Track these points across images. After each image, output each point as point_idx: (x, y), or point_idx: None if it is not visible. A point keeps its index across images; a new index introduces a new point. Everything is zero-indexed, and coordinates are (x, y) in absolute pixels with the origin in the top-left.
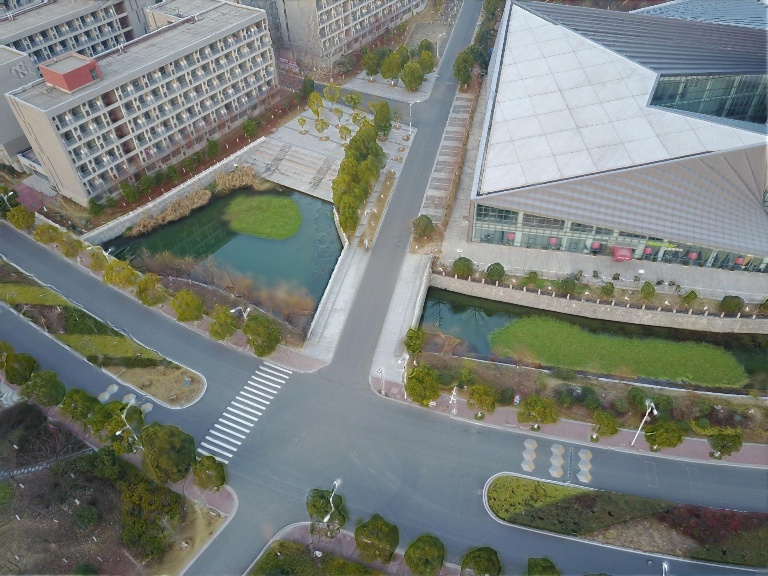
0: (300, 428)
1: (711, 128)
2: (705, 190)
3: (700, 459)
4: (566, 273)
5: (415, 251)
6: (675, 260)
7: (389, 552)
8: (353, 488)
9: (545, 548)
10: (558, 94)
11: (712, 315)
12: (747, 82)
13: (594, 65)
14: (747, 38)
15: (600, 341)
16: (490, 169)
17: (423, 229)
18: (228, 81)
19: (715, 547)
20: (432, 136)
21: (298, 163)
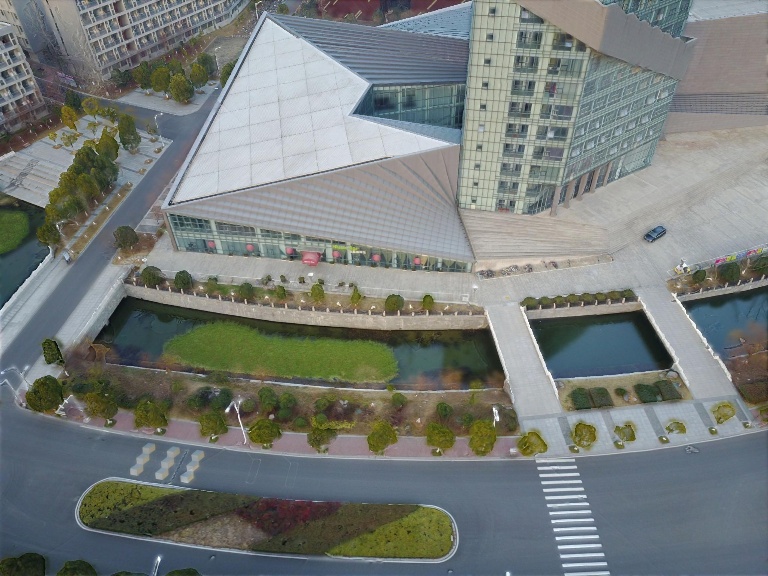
0: None
1: (397, 135)
2: (390, 194)
3: (306, 454)
4: (256, 278)
5: (117, 262)
6: (363, 262)
7: None
8: None
9: (118, 550)
10: (276, 105)
11: (376, 314)
12: None
13: (317, 76)
14: (462, 49)
15: (271, 344)
16: (189, 179)
17: (122, 240)
18: None
19: (277, 538)
20: (184, 148)
21: (42, 177)
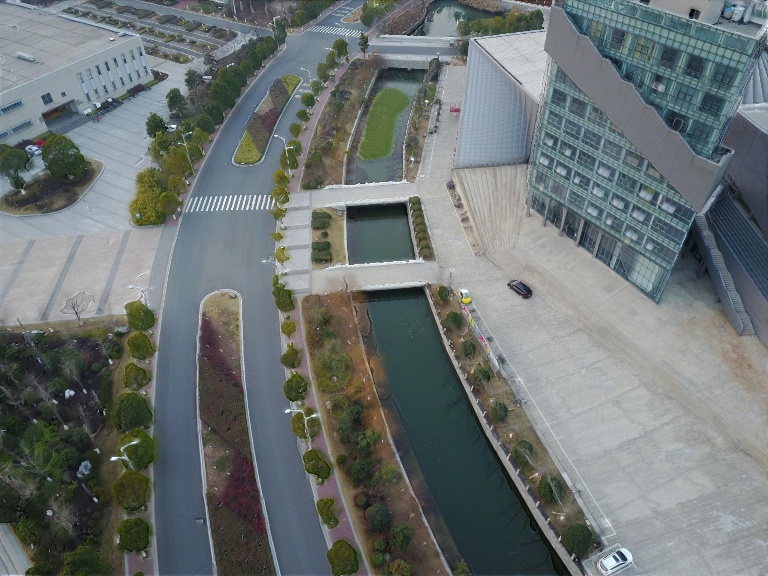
0: None
1: None
2: None
3: None
4: None
5: None
6: None
7: None
8: None
9: None
10: None
11: None
12: None
13: None
14: None
15: (392, 117)
16: None
17: None
18: None
19: None
20: None
21: None
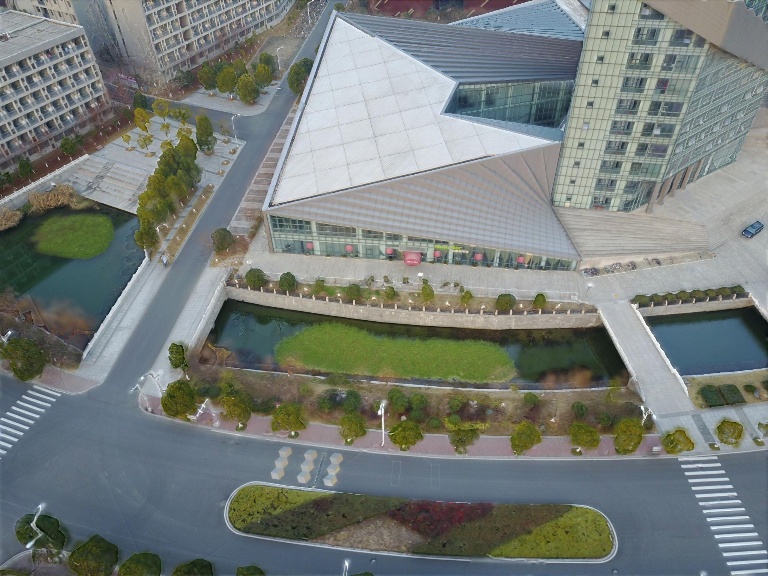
0: (54, 452)
1: (494, 133)
2: (490, 193)
3: (445, 455)
4: (359, 279)
5: (215, 264)
6: (464, 262)
7: (104, 573)
8: (96, 510)
9: (275, 555)
10: (362, 104)
11: (487, 313)
12: (547, 88)
13: (400, 75)
14: (544, 47)
15: (383, 345)
16: (286, 180)
17: (220, 242)
18: (46, 99)
19: (436, 540)
20: (259, 148)
21: (119, 180)
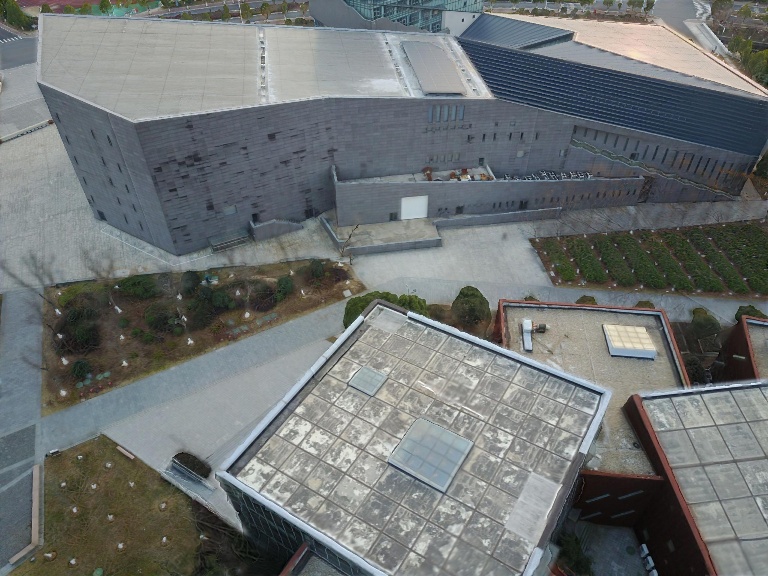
0: None
1: None
2: None
3: None
4: None
5: None
6: None
7: None
8: None
9: None
10: (649, 44)
11: None
12: None
13: (631, 50)
14: None
15: None
16: None
17: None
18: None
19: None
20: None
21: None
